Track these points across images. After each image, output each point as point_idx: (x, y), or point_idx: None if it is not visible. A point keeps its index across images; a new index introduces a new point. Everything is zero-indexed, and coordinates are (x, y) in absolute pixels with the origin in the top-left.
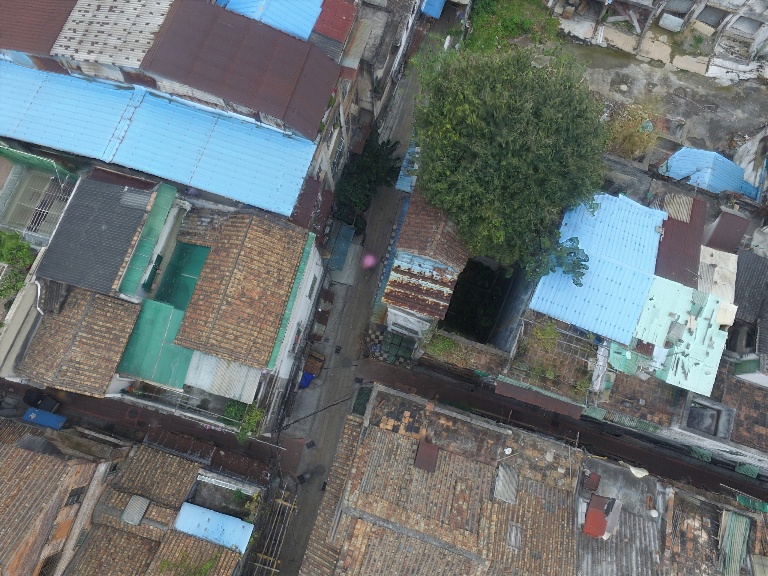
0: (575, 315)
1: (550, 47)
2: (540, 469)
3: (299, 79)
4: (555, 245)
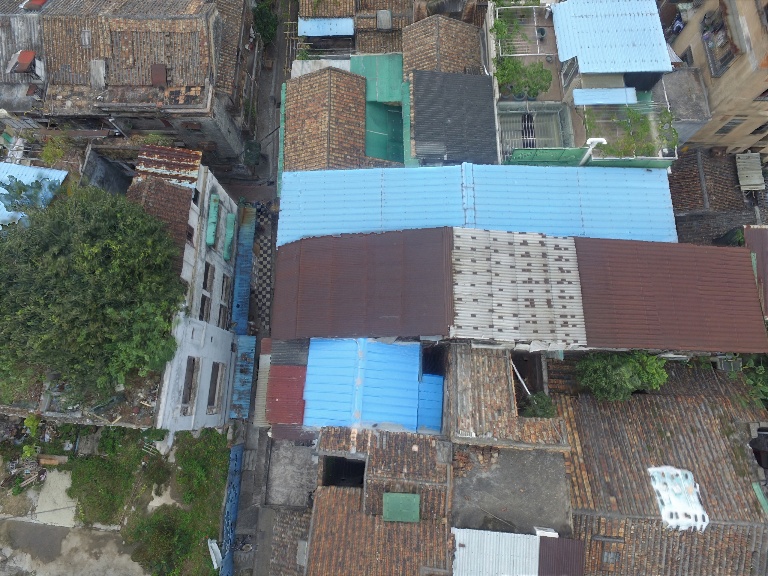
0: (26, 173)
1: None
2: (75, 94)
3: (298, 289)
4: (32, 207)
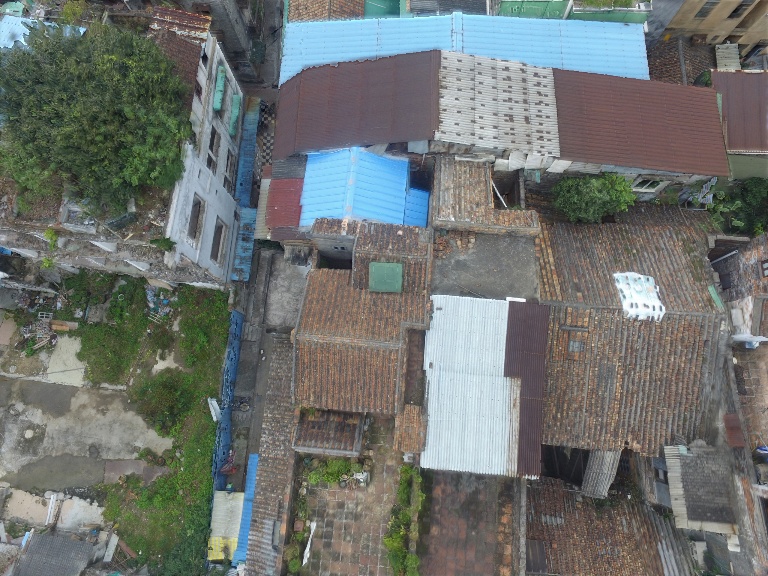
0: None
1: (116, 474)
2: None
3: None
4: None
